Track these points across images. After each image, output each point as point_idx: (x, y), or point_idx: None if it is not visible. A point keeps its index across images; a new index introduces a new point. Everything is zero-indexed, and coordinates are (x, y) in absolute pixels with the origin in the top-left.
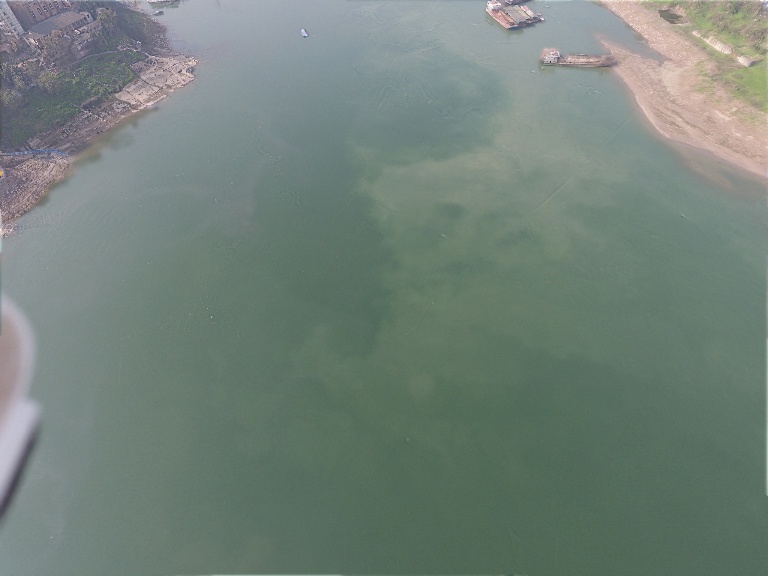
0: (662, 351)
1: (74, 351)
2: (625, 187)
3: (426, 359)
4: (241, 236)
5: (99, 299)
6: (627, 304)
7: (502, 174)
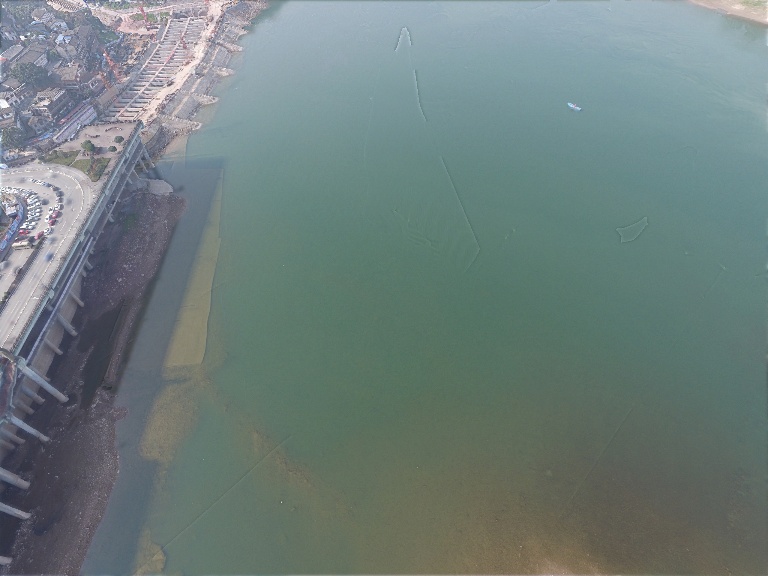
0: (587, 46)
1: (305, 52)
2: (580, 3)
3: None
4: None
5: (308, 40)
6: (573, 35)
7: (511, 2)
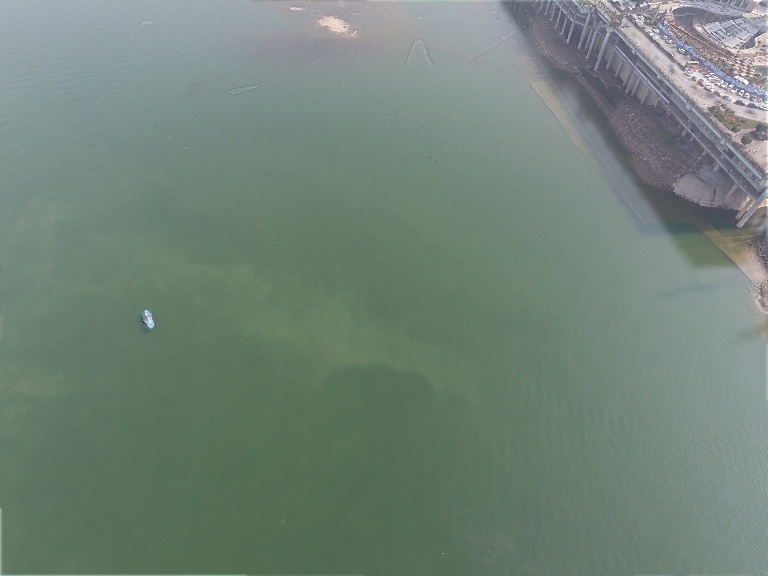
0: None
1: None
2: None
3: None
4: None
5: None
6: None
7: None
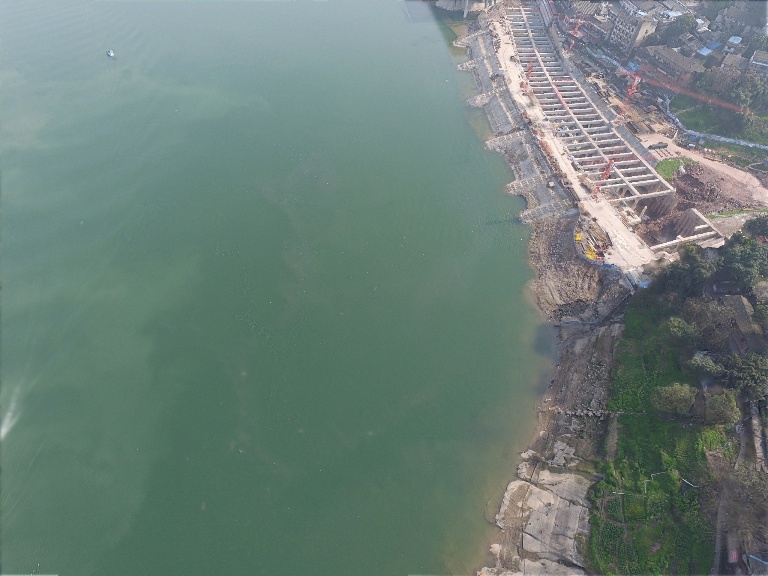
0: None
1: (387, 136)
2: None
3: (148, 135)
4: (280, 210)
5: (390, 164)
6: None
7: None
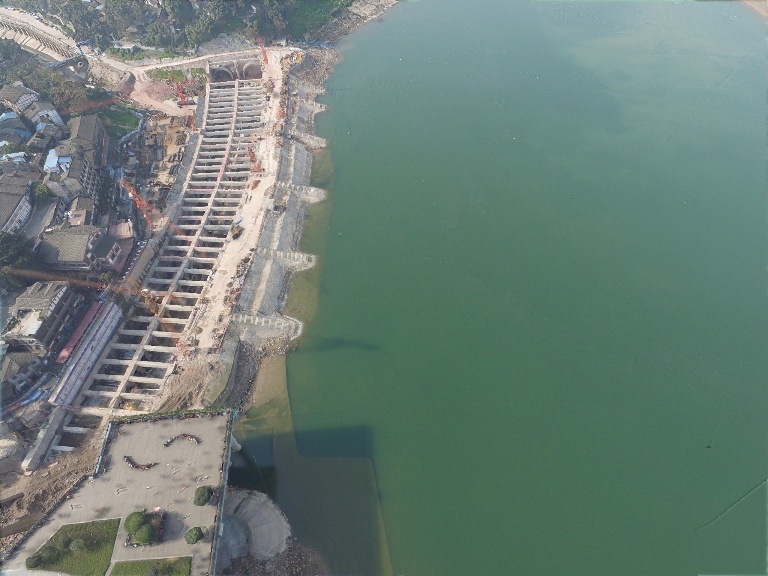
0: None
1: (424, 155)
2: None
3: (680, 163)
4: None
5: (421, 130)
6: None
7: (680, 68)
